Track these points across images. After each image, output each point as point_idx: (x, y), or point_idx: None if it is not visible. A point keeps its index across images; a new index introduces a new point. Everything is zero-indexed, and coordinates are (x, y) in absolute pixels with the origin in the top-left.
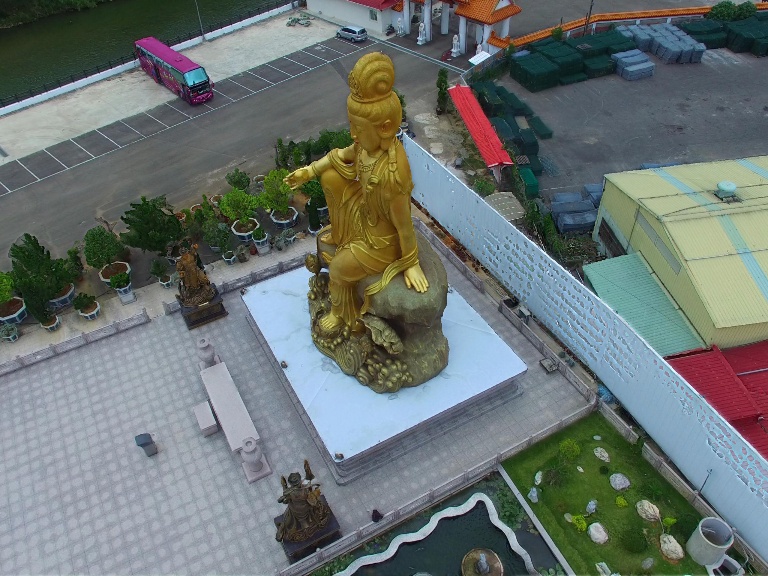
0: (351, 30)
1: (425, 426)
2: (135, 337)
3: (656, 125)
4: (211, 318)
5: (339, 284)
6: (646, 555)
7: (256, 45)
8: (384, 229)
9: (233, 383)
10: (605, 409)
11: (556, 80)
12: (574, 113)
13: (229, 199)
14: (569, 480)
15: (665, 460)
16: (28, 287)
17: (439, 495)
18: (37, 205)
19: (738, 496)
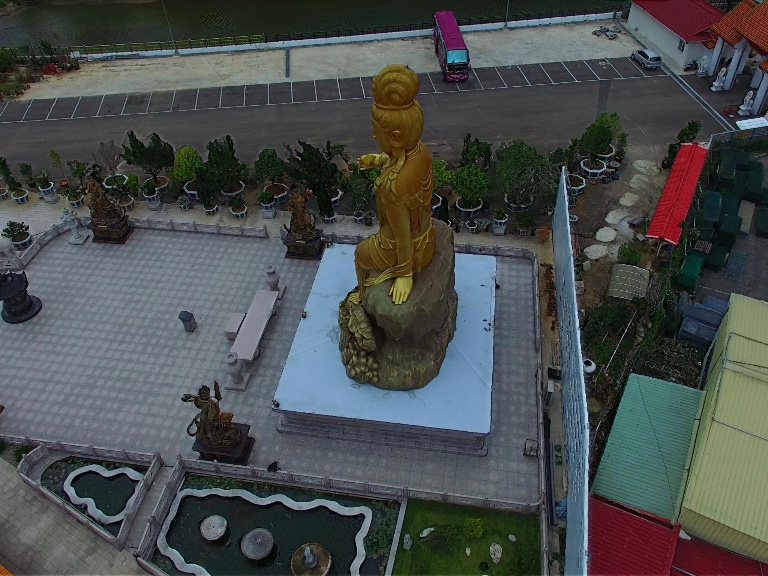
0: (645, 54)
1: (372, 427)
2: (249, 244)
3: None
4: (305, 256)
5: (357, 266)
6: None
7: (547, 44)
8: (390, 232)
9: (270, 310)
10: (541, 518)
11: None
12: None
13: None
14: (450, 552)
15: None
16: (203, 174)
17: (337, 487)
18: (276, 121)
19: None
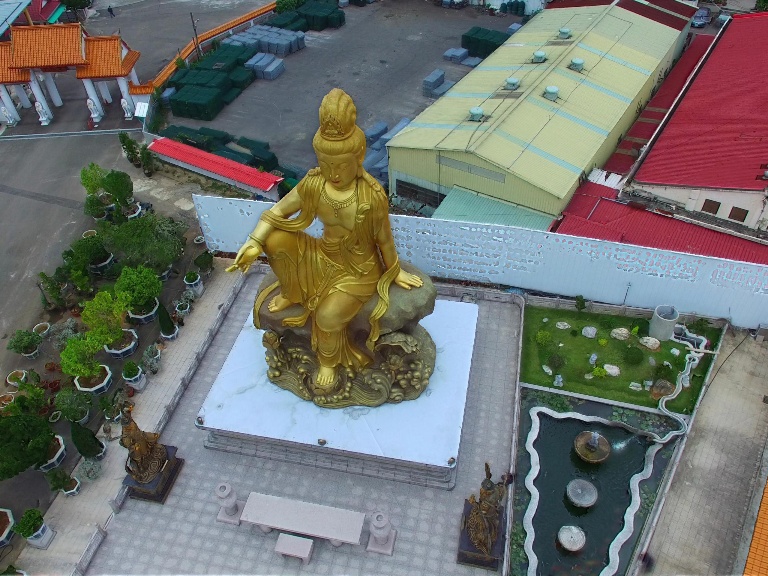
0: None
1: None
2: (111, 561)
3: None
4: (174, 476)
5: (339, 330)
6: (646, 358)
7: None
8: (368, 252)
9: (285, 499)
10: (532, 299)
11: (222, 102)
12: (263, 122)
13: (72, 356)
14: (563, 356)
15: None
16: None
17: None
18: None
19: (652, 287)
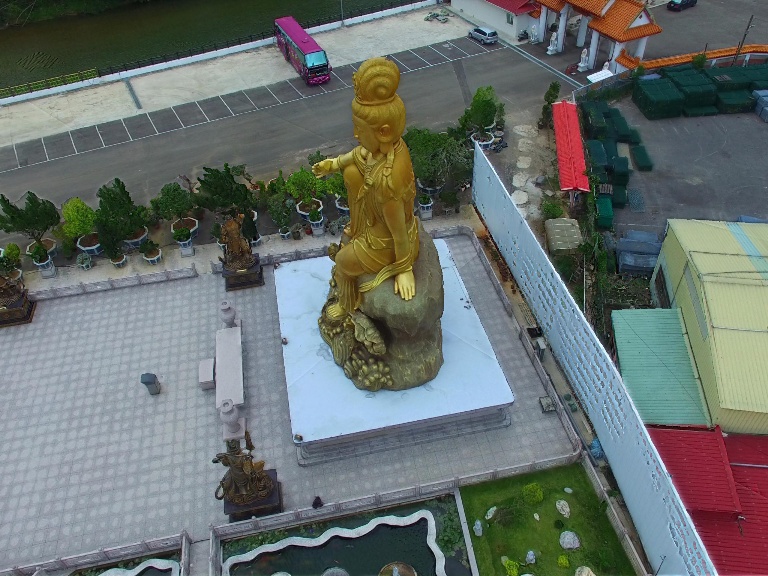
0: (482, 31)
1: (397, 432)
2: (180, 287)
3: None
4: (248, 285)
5: (341, 276)
6: None
7: (388, 35)
8: (382, 231)
9: (240, 347)
10: (587, 463)
11: (679, 110)
12: (687, 148)
13: (295, 178)
14: (521, 524)
15: (635, 533)
16: (103, 225)
17: (387, 501)
18: (148, 155)
19: None
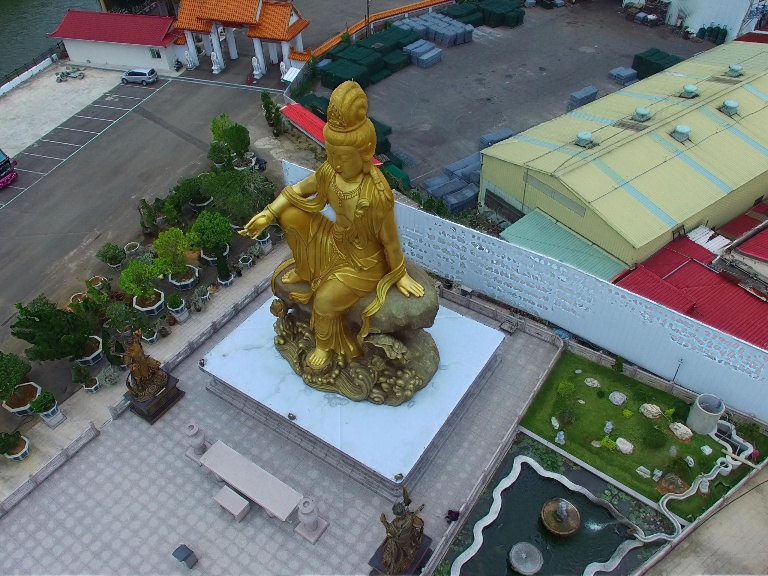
0: (139, 73)
1: None
2: (92, 456)
3: (469, 101)
4: (170, 404)
5: (331, 317)
6: (669, 445)
7: (33, 110)
8: (371, 249)
9: (242, 456)
10: (573, 346)
11: (368, 81)
12: (398, 107)
13: (129, 275)
14: (579, 414)
15: None
16: None
17: (488, 473)
18: None
19: (708, 371)
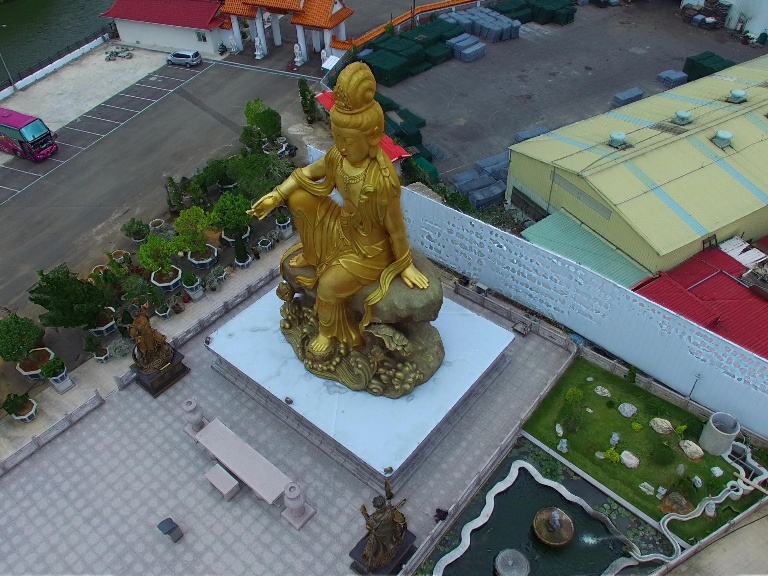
0: (183, 55)
1: None
2: (95, 424)
3: (508, 98)
4: (175, 379)
5: (333, 303)
6: (676, 463)
7: (80, 86)
8: (376, 236)
9: (237, 436)
10: (586, 352)
11: (407, 72)
12: (435, 100)
13: (147, 250)
14: (585, 423)
15: None
16: None
17: (483, 475)
18: None
19: (726, 389)
